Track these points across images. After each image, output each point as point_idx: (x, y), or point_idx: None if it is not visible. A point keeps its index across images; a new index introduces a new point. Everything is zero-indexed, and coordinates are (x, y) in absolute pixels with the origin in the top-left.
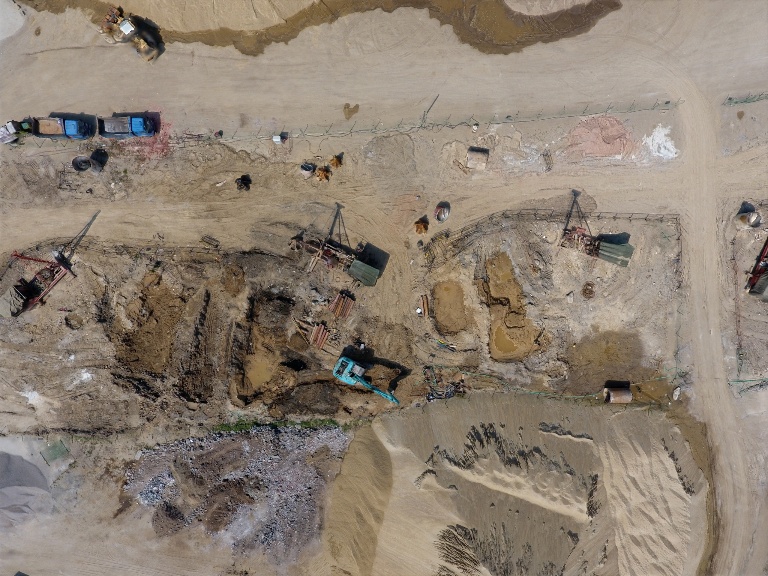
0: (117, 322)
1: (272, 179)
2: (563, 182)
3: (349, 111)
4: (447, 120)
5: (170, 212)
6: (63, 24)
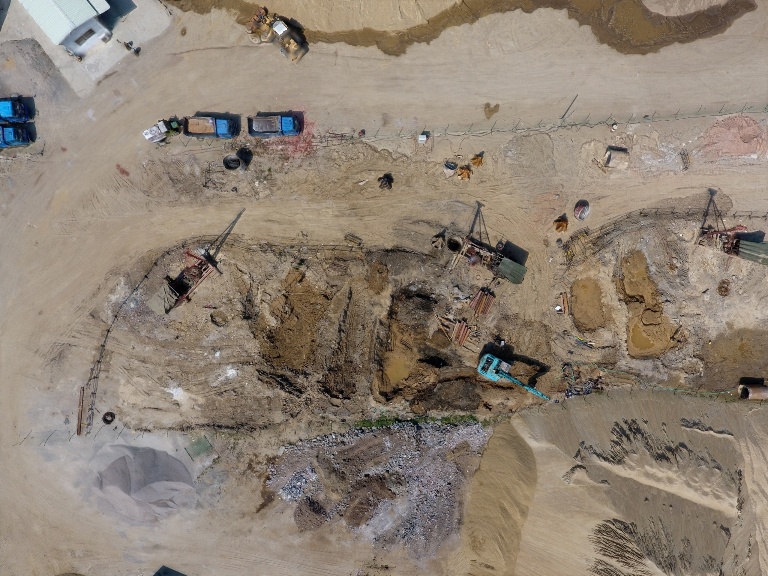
0: (261, 319)
1: (414, 178)
2: (699, 181)
3: (489, 111)
4: (590, 119)
5: (314, 210)
6: (208, 24)
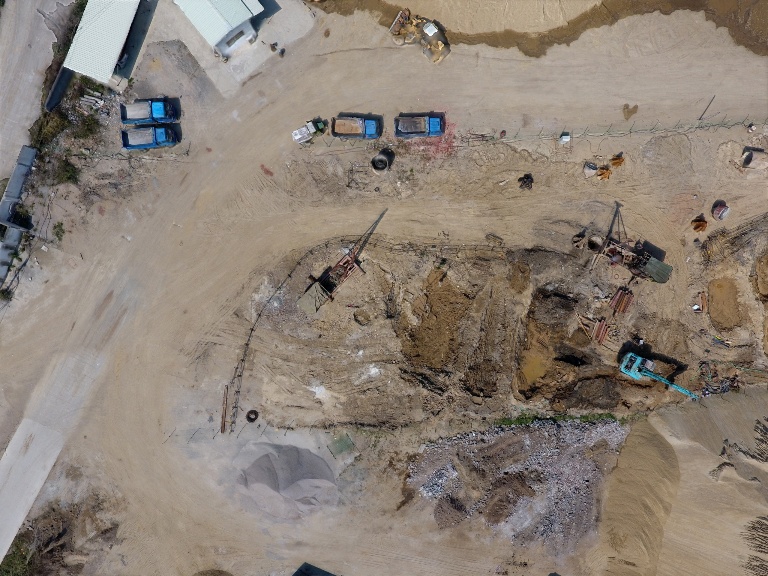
0: (403, 318)
1: (554, 178)
2: None
3: (628, 111)
4: (730, 120)
5: (455, 210)
6: (351, 26)
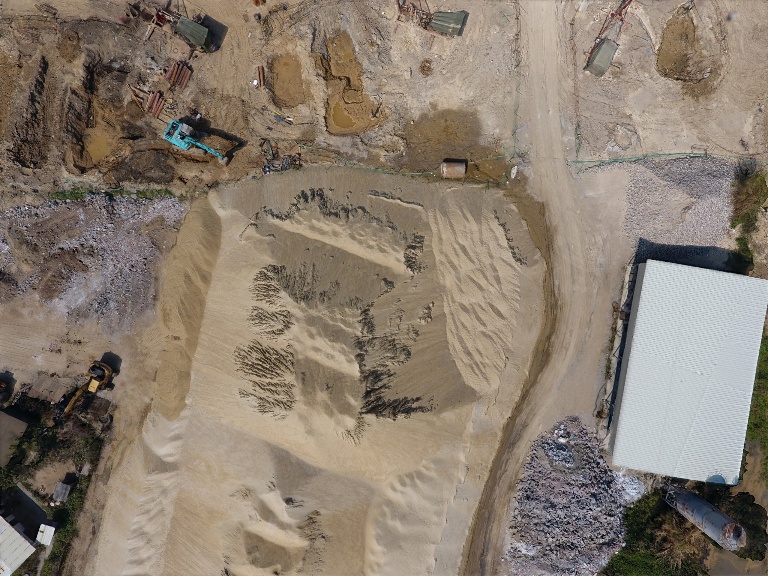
0: None
1: None
2: None
3: None
4: None
5: None
6: None
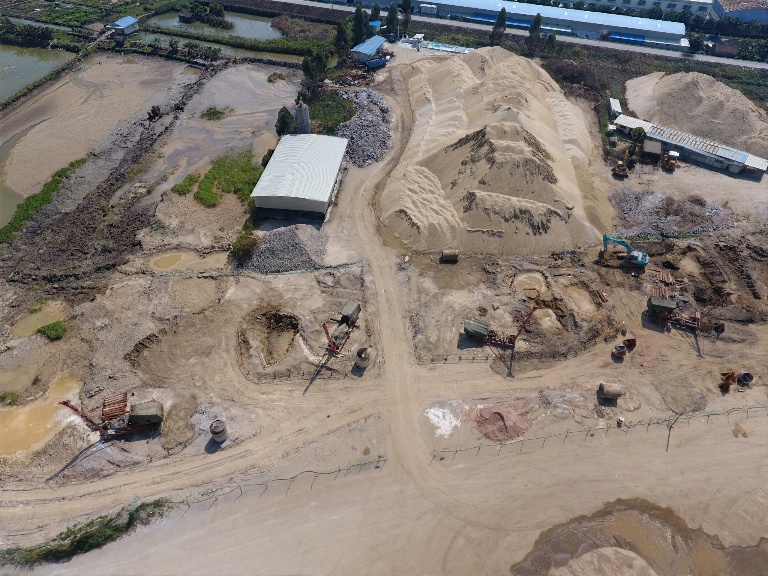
0: None
1: (767, 373)
2: (524, 384)
3: (740, 431)
4: None
5: None
6: None
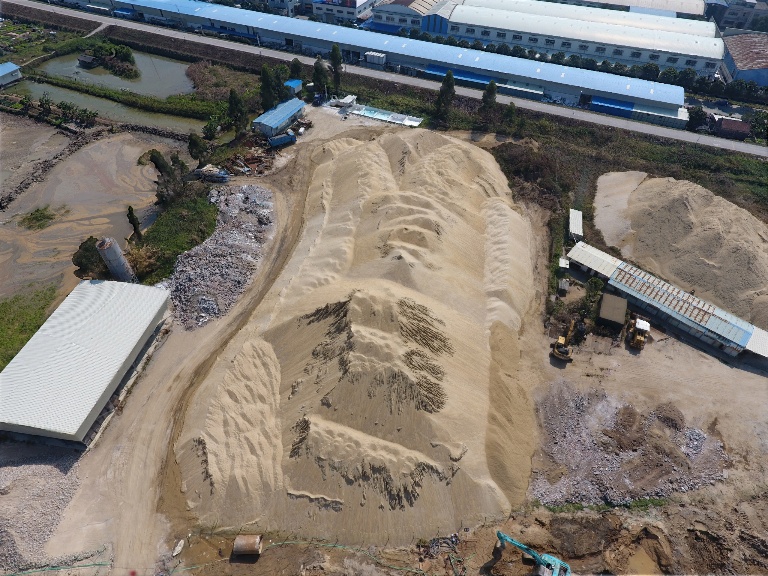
0: None
1: None
2: None
3: None
4: None
5: None
6: None
